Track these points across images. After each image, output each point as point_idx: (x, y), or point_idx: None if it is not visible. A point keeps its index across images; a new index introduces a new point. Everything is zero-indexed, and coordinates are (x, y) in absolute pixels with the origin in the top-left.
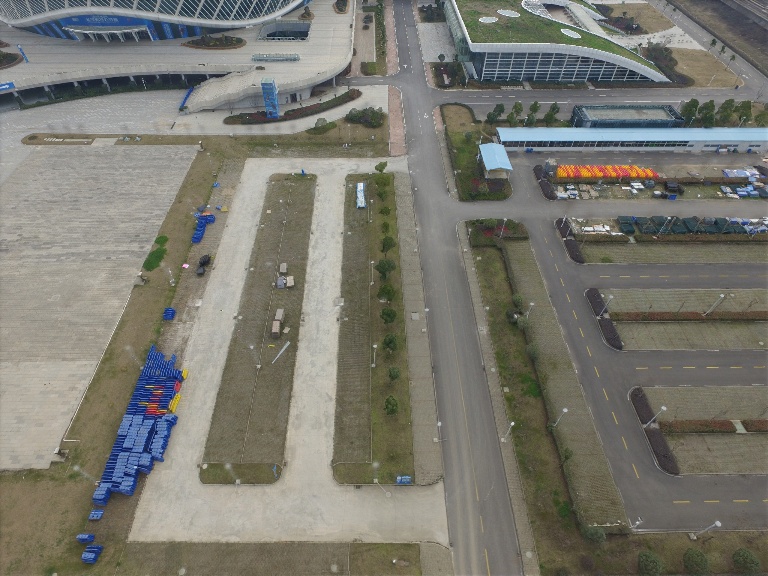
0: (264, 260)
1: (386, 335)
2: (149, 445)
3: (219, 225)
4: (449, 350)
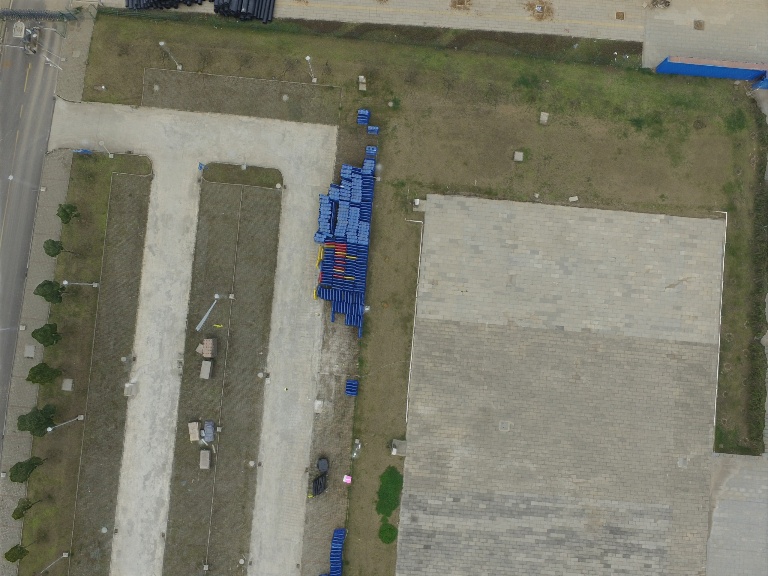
0: (235, 481)
1: (50, 298)
2: (334, 208)
3: (311, 569)
4: (0, 297)
